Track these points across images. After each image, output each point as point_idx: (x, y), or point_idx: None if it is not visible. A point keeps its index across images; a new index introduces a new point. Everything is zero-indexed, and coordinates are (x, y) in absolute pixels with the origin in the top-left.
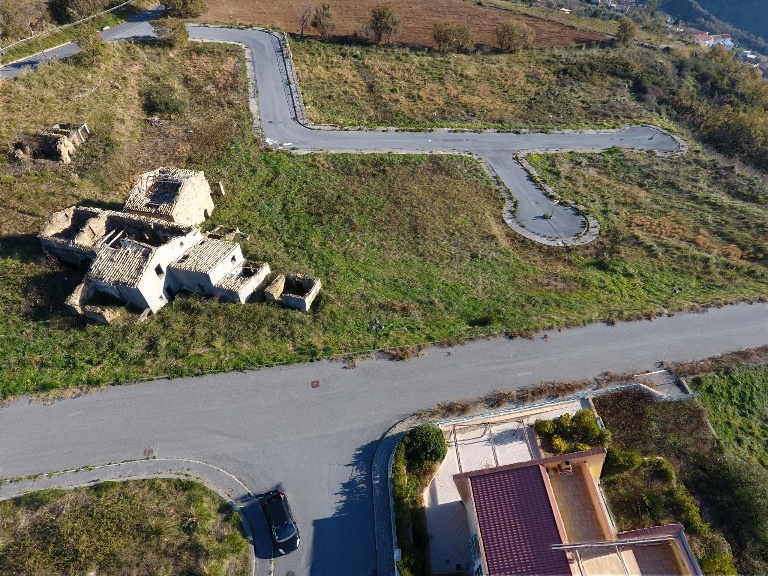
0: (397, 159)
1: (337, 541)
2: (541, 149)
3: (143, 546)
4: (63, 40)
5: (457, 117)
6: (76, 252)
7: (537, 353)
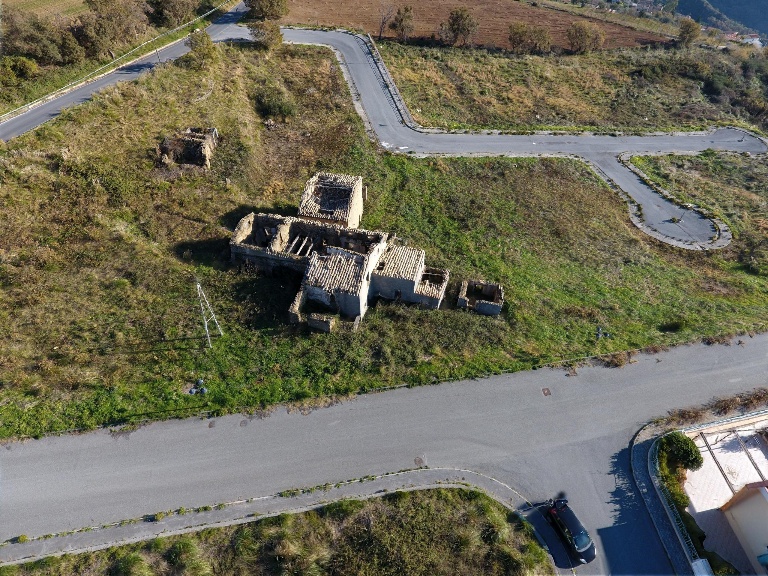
0: (511, 162)
1: (627, 550)
2: (641, 152)
3: (453, 557)
4: (162, 43)
5: (551, 119)
6: (271, 259)
7: (739, 359)
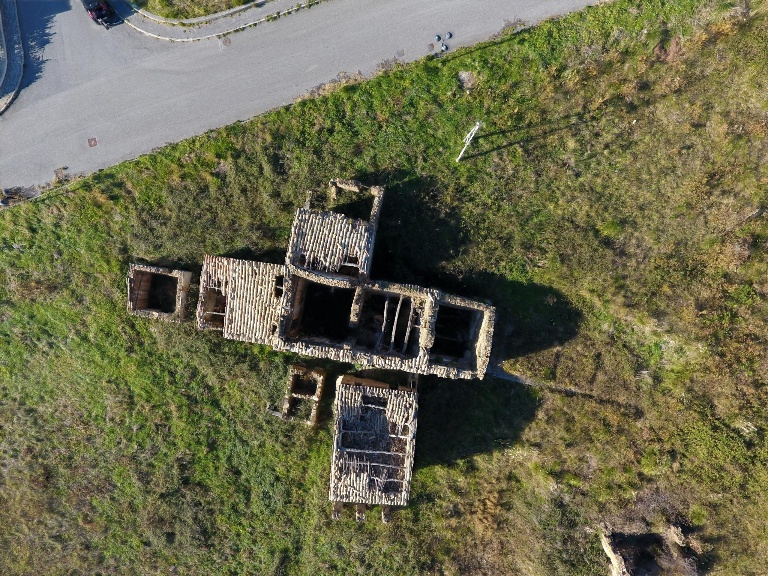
0: None
1: None
2: None
3: None
4: None
5: None
6: None
7: None
